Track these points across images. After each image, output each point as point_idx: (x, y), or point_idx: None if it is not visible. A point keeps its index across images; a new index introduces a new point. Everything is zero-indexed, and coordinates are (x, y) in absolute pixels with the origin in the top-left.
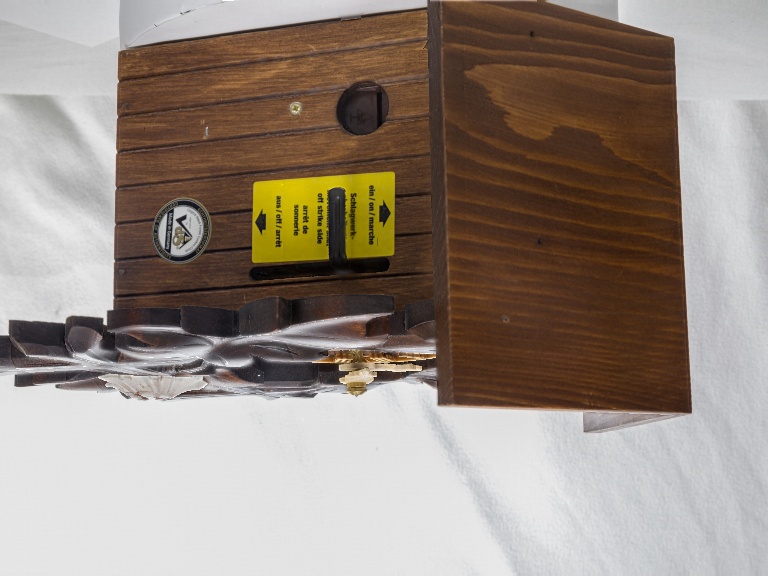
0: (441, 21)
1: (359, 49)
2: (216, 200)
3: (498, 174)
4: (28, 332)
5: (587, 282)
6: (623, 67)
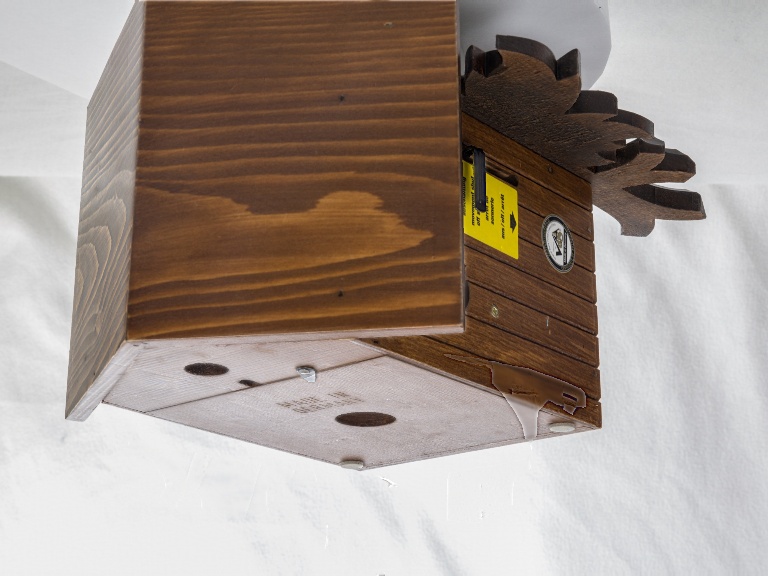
0: (462, 278)
1: (455, 346)
2: (540, 258)
3: (393, 149)
4: (681, 163)
5: (281, 73)
6: (210, 291)
